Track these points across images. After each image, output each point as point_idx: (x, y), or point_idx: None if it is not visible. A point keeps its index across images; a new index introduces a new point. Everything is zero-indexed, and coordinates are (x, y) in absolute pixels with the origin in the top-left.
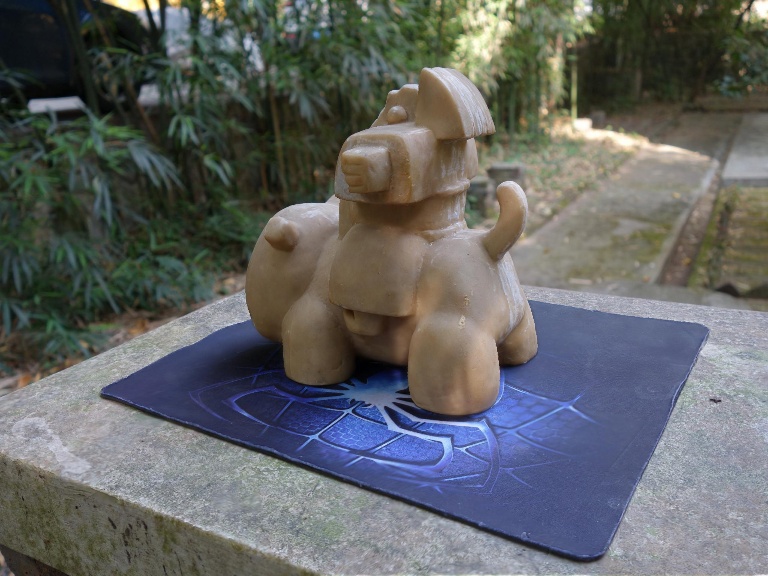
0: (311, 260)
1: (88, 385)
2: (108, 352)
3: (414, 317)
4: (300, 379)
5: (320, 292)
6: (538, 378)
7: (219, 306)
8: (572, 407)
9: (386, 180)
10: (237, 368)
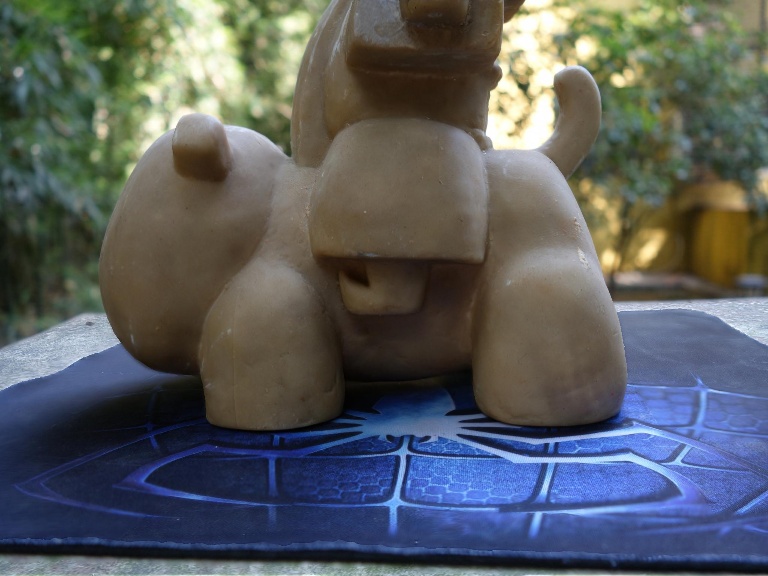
0: (260, 197)
1: None
2: None
3: (480, 270)
4: (260, 422)
5: (286, 252)
6: None
7: None
8: (714, 390)
9: None
10: (96, 432)
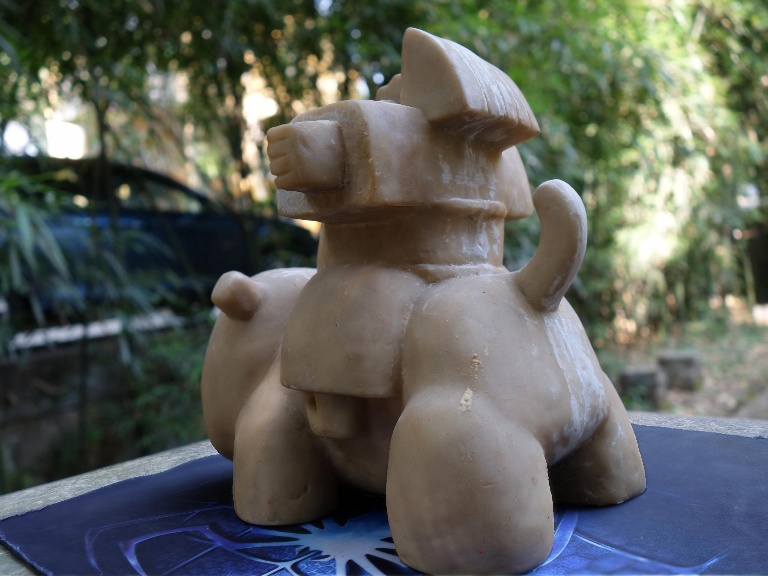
0: (274, 331)
1: None
2: (55, 483)
3: (401, 402)
4: (245, 515)
5: None
6: (638, 526)
7: None
8: None
9: (334, 167)
10: (182, 502)
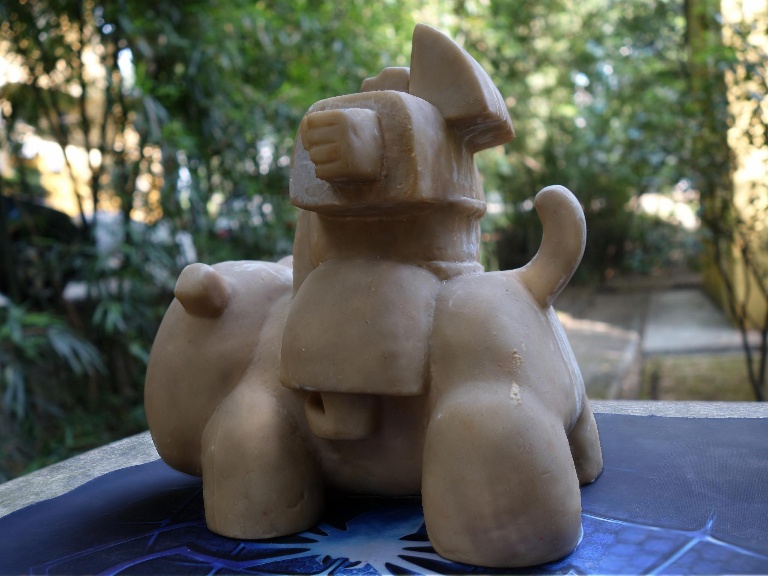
0: (250, 329)
1: None
2: None
3: (426, 400)
4: (232, 530)
5: (265, 378)
6: (626, 500)
7: (112, 449)
8: (712, 538)
9: (376, 159)
10: (125, 524)
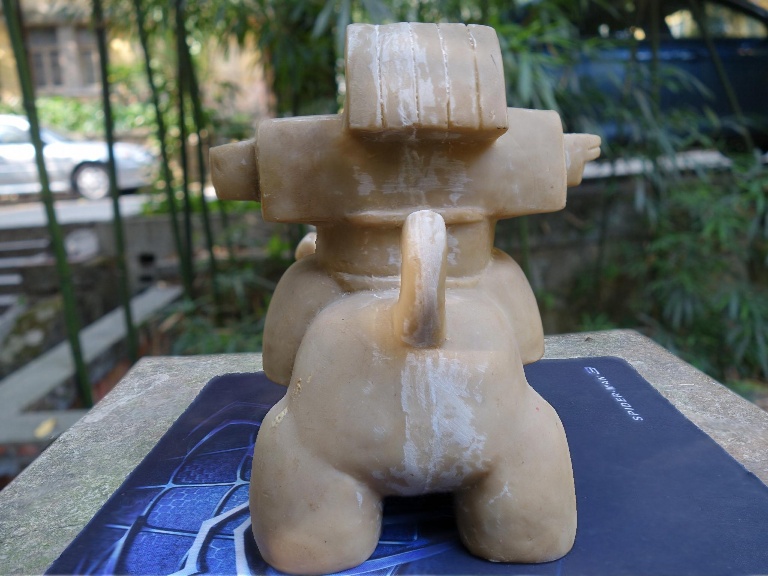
0: None
1: (234, 368)
2: None
3: None
4: None
5: None
6: None
7: None
8: None
9: (246, 185)
10: None
